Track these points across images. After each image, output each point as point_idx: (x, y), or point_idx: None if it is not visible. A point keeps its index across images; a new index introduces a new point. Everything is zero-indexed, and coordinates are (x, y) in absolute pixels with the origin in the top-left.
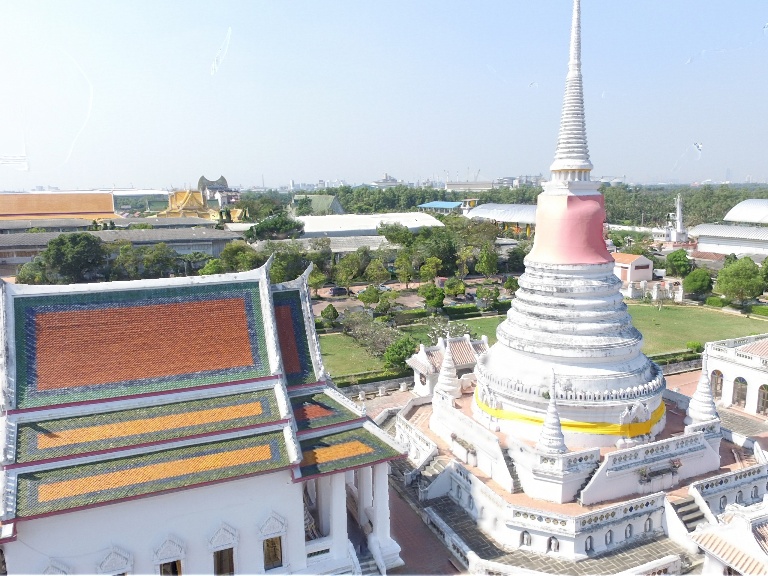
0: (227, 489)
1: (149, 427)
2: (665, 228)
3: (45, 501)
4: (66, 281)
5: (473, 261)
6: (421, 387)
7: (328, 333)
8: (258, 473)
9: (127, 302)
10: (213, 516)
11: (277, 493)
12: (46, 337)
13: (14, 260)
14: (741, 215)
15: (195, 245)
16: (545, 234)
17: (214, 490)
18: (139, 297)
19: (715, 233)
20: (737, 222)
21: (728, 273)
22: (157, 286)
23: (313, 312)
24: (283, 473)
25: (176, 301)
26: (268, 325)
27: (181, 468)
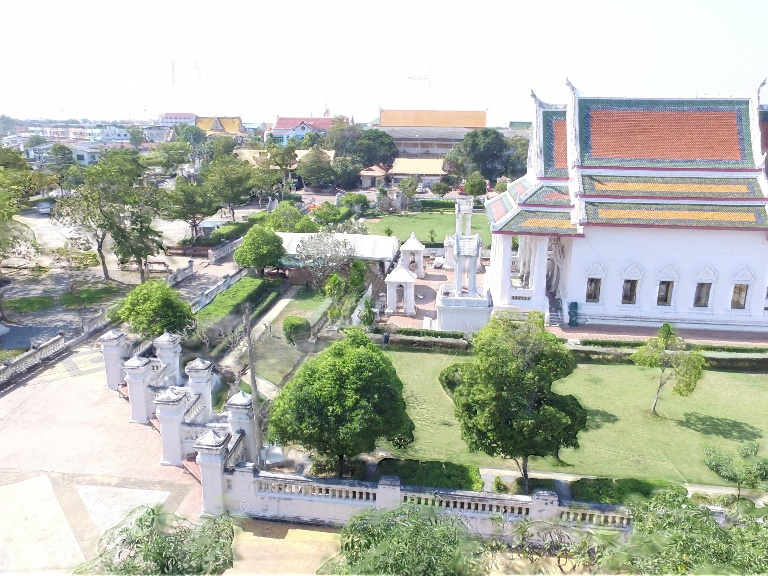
0: (716, 239)
1: (665, 188)
2: None
3: (603, 217)
4: (475, 168)
5: None
6: None
7: None
8: (745, 228)
9: (649, 108)
10: (702, 256)
11: (753, 251)
12: (597, 125)
13: (435, 150)
14: None
15: None
16: None
17: (707, 238)
18: (657, 105)
19: None
20: None
21: None
22: (671, 98)
23: None
24: (761, 236)
25: (683, 110)
26: (755, 133)
27: (688, 215)
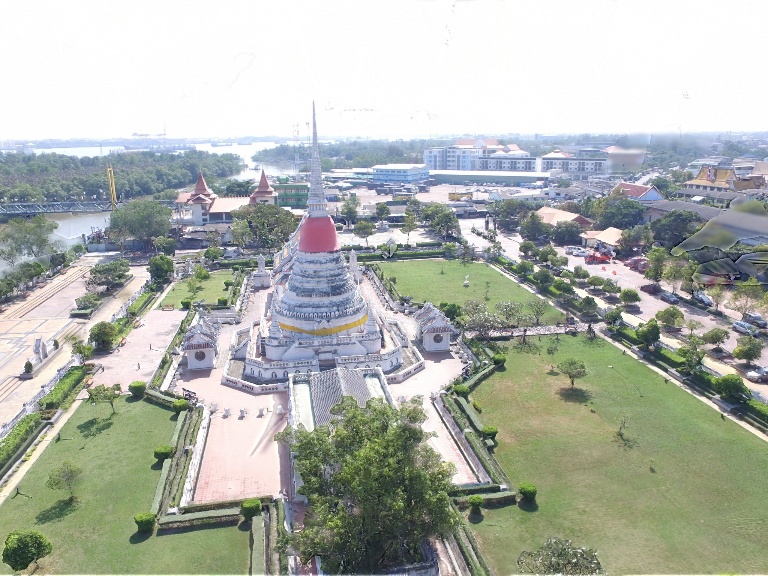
0: None
1: None
2: None
3: None
4: (666, 245)
5: None
6: None
7: (576, 316)
8: None
9: None
10: None
11: None
12: None
13: None
14: None
15: None
16: None
17: None
18: None
19: None
20: None
21: None
22: None
23: (654, 313)
24: None
25: None
26: None
27: None
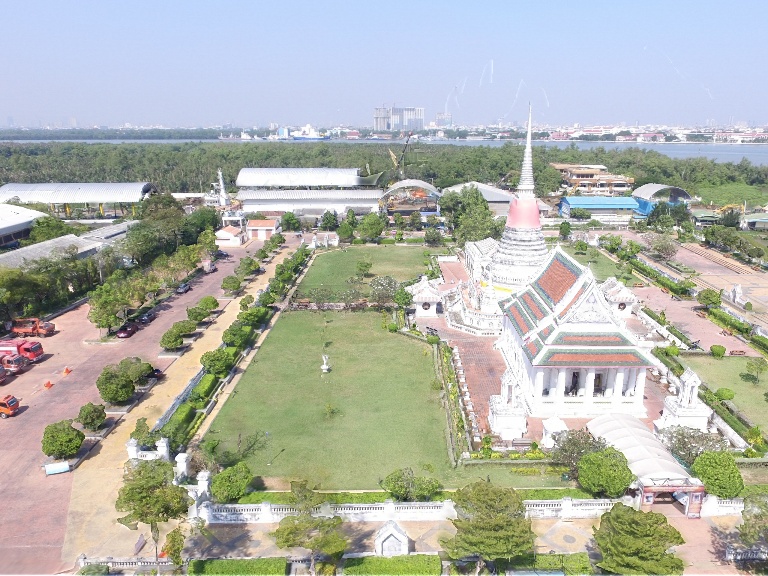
0: None
1: None
2: None
3: None
4: None
5: (167, 244)
6: (425, 312)
7: (275, 315)
8: None
9: None
10: None
11: None
12: None
13: None
14: (249, 181)
15: None
16: (530, 217)
17: None
18: None
19: (258, 197)
20: (247, 186)
21: (371, 223)
22: None
23: None
24: None
25: None
26: None
27: None
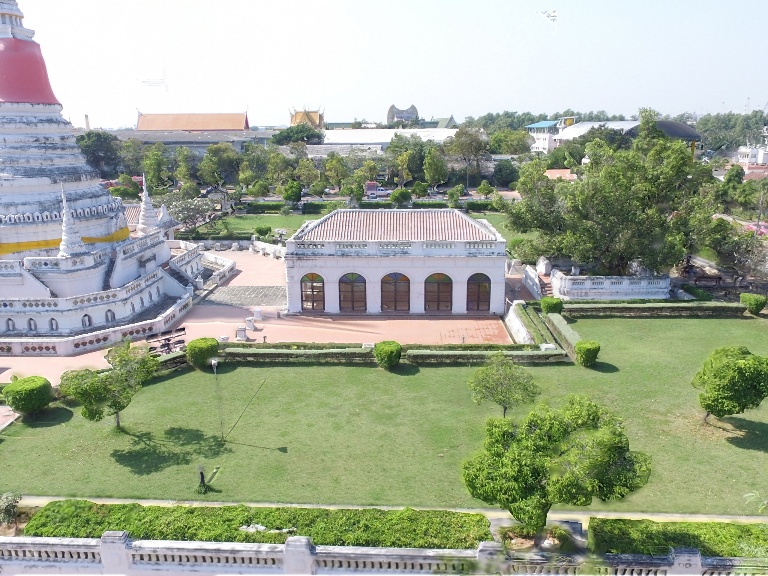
0: None
1: None
2: (758, 147)
3: None
4: None
5: (451, 172)
6: None
7: None
8: None
9: None
10: None
11: None
12: None
13: None
14: None
15: (200, 147)
16: None
17: None
18: None
19: None
20: None
21: None
22: None
23: None
24: None
25: None
26: None
27: None
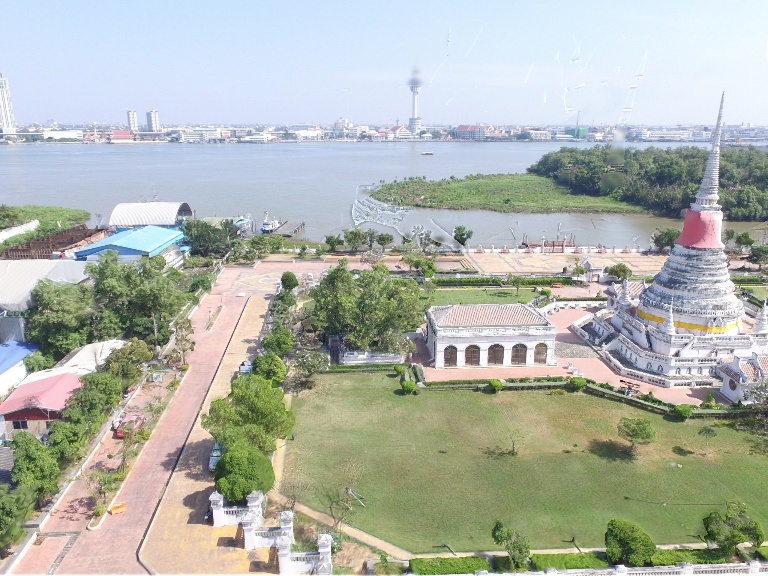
0: None
1: None
2: None
3: None
4: None
5: None
6: None
7: None
8: None
9: None
10: None
11: None
12: None
13: None
14: None
15: None
16: None
17: None
18: None
19: None
20: None
21: None
22: None
23: None
24: None
25: None
26: None
27: None
